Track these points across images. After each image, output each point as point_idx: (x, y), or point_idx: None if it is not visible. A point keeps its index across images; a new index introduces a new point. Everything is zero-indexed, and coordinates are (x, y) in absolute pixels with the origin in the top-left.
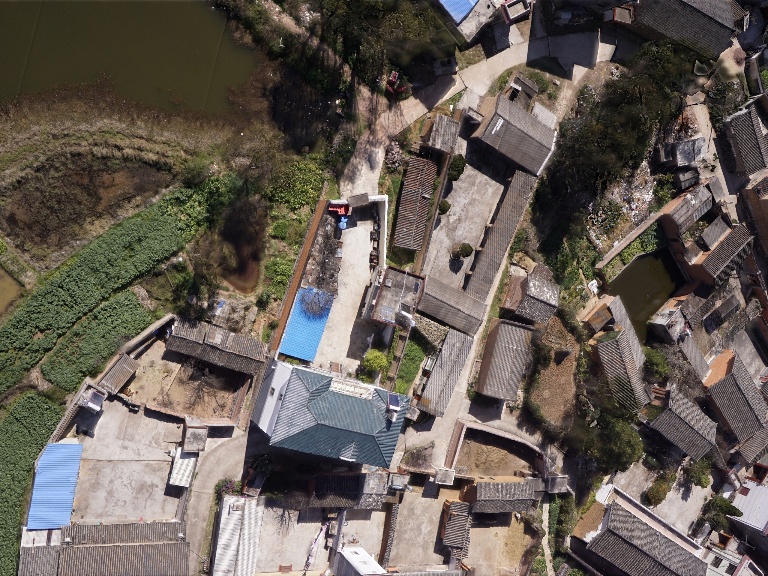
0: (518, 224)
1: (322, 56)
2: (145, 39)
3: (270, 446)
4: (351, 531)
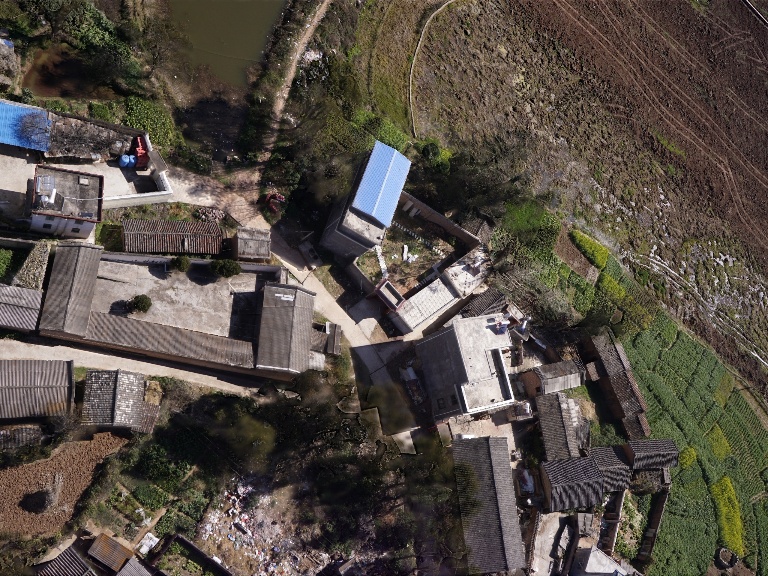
0: (193, 382)
1: (267, 133)
2: (219, 6)
3: None
4: None
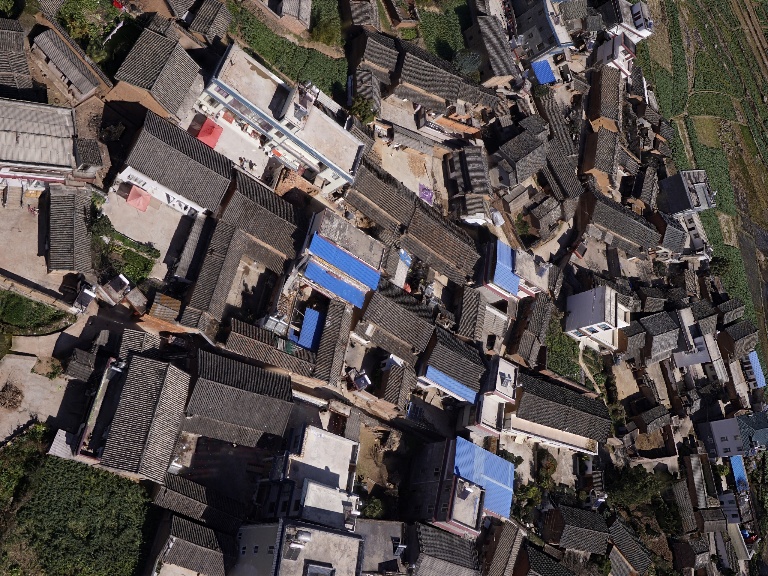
0: None
1: None
2: None
3: (715, 409)
4: (677, 375)
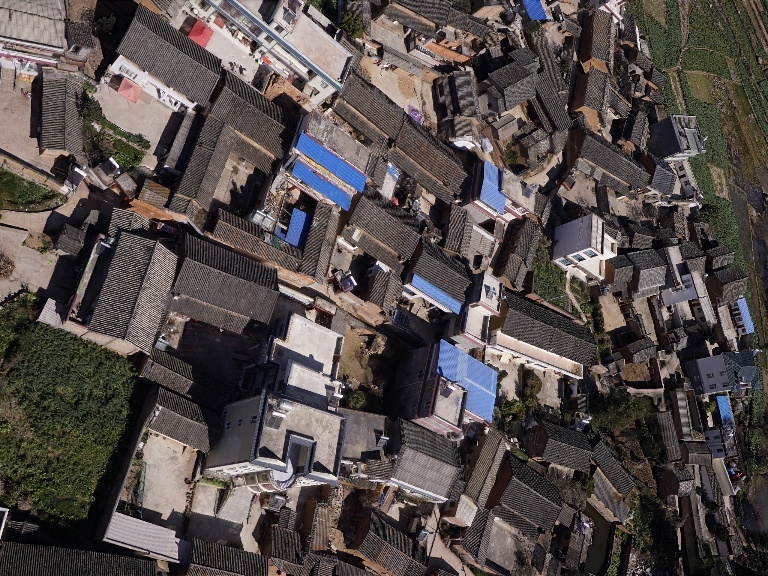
0: None
1: (761, 546)
2: None
3: (702, 350)
4: (665, 314)
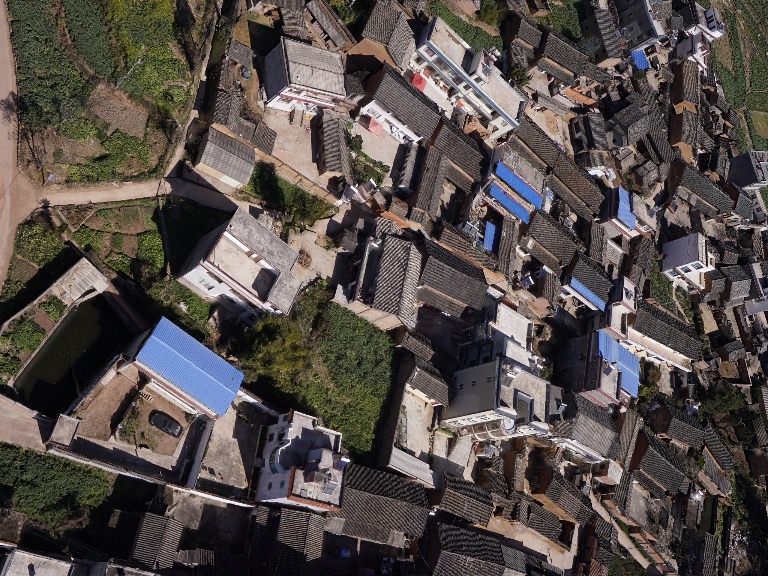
0: None
1: None
2: None
3: None
4: None
